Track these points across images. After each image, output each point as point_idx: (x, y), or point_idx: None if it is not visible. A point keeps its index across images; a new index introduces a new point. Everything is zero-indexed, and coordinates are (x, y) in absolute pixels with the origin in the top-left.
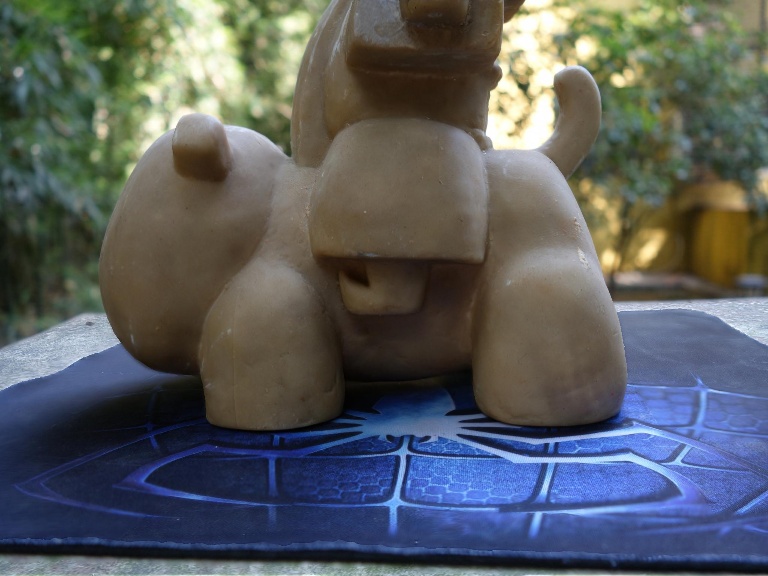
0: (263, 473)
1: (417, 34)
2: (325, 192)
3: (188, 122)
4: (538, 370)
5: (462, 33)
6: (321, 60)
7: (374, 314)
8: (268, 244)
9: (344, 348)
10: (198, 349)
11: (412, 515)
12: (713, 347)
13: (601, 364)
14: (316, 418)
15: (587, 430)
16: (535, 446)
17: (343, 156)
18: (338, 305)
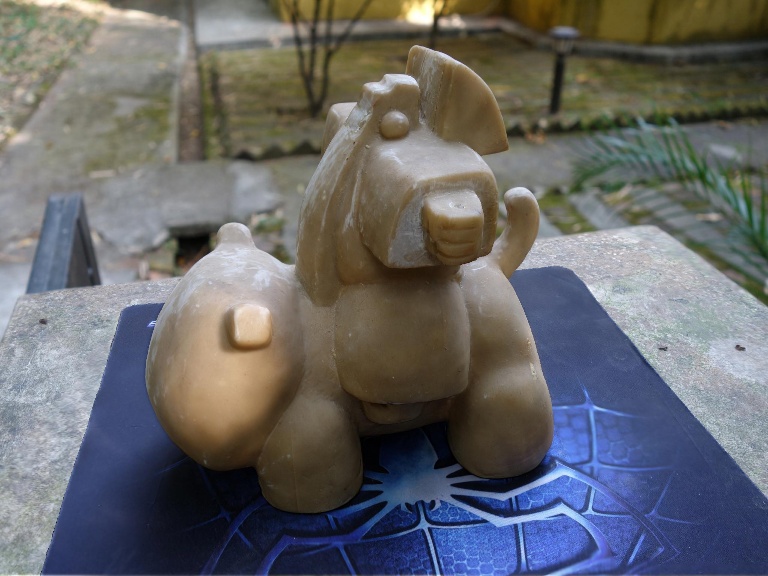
0: (344, 567)
1: (435, 256)
2: (357, 356)
3: (245, 319)
4: (504, 452)
5: None
6: (332, 223)
7: None
8: (307, 384)
9: (359, 431)
10: (258, 460)
11: None
12: (587, 336)
13: (542, 440)
14: (352, 495)
15: (530, 477)
16: (504, 503)
17: (370, 330)
18: (358, 411)
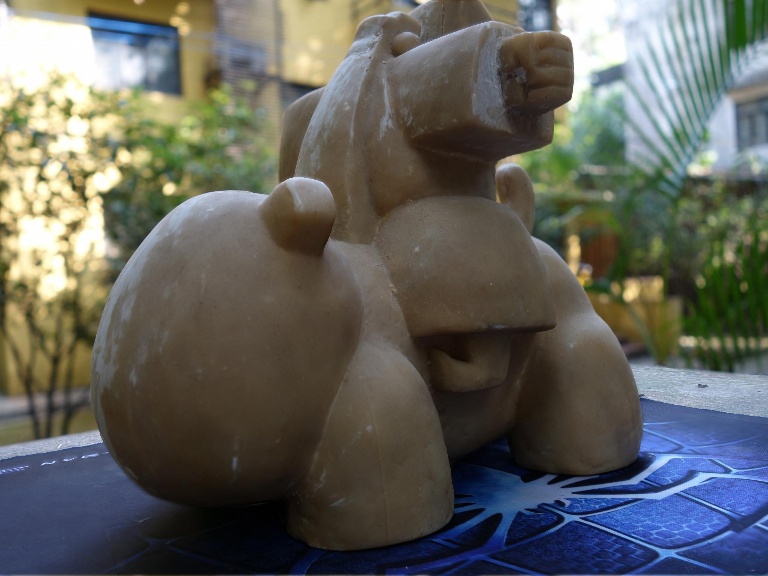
0: (513, 571)
1: (513, 120)
2: (436, 266)
3: (305, 186)
4: (611, 419)
5: (537, 125)
6: (361, 134)
7: (477, 389)
8: (369, 326)
9: None
10: (312, 460)
11: (701, 555)
12: None
13: (639, 407)
14: (452, 511)
15: (640, 466)
16: (640, 485)
17: (447, 230)
18: None
